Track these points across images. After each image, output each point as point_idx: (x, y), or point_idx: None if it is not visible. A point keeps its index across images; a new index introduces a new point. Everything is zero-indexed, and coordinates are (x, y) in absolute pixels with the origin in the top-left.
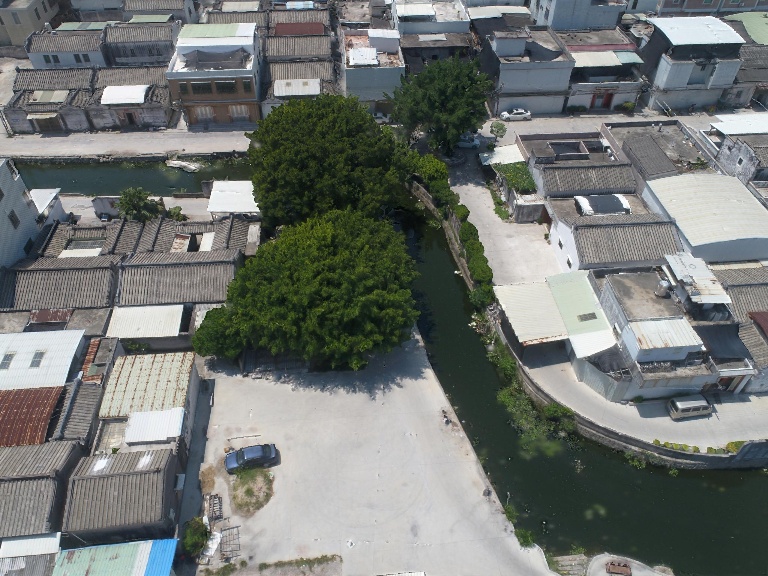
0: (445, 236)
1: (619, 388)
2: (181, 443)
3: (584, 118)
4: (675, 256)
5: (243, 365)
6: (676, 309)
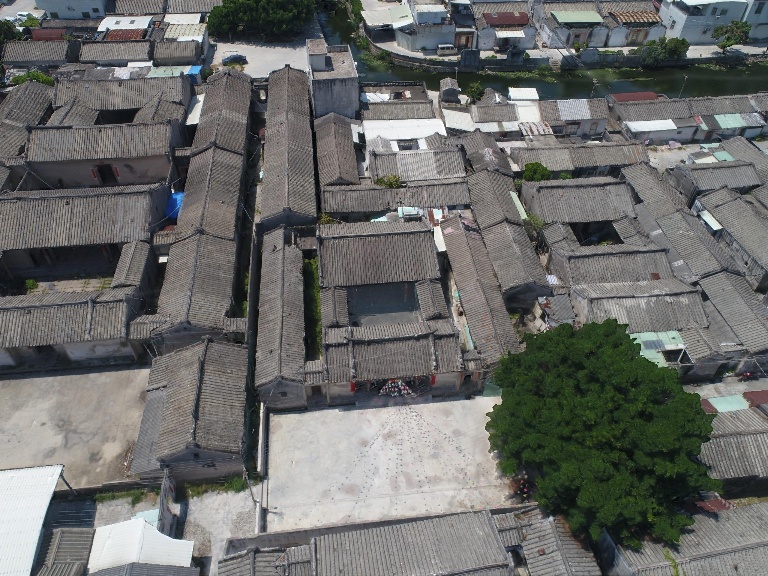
0: (346, 10)
1: (412, 40)
2: (202, 48)
3: None
4: None
5: (231, 38)
6: (439, 1)
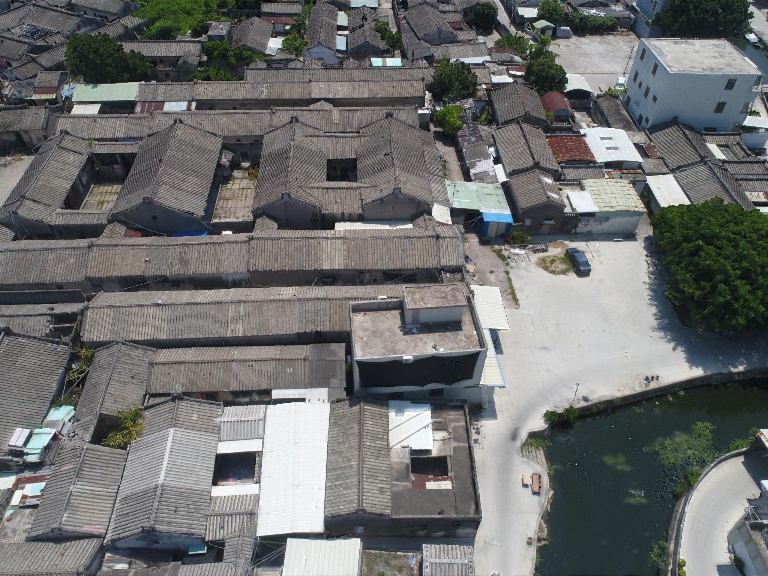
0: None
1: None
2: (575, 218)
3: None
4: None
5: (654, 250)
6: None
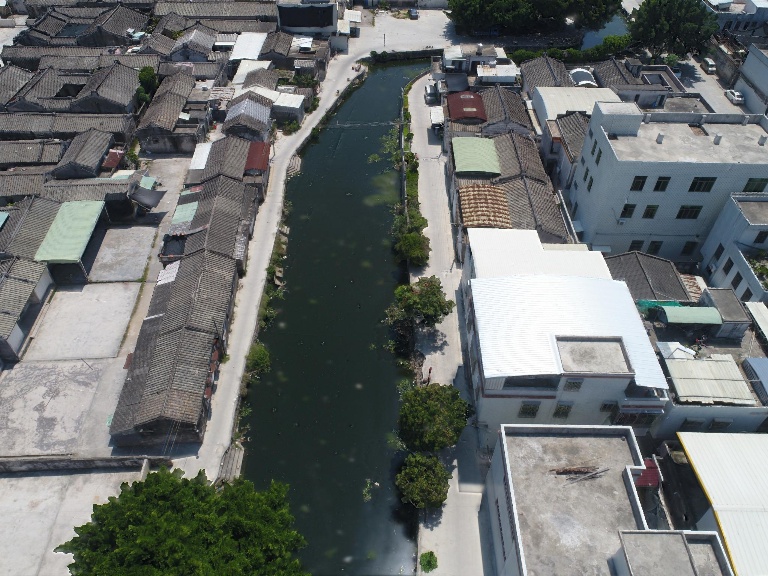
0: None
1: None
2: None
3: None
4: (515, 68)
5: None
6: None
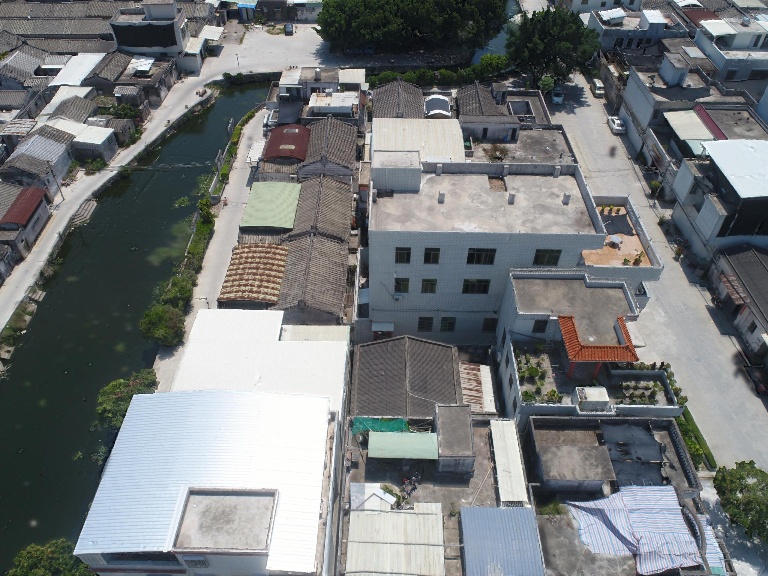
0: None
1: None
2: (294, 8)
3: (631, 166)
4: (354, 96)
5: None
6: None
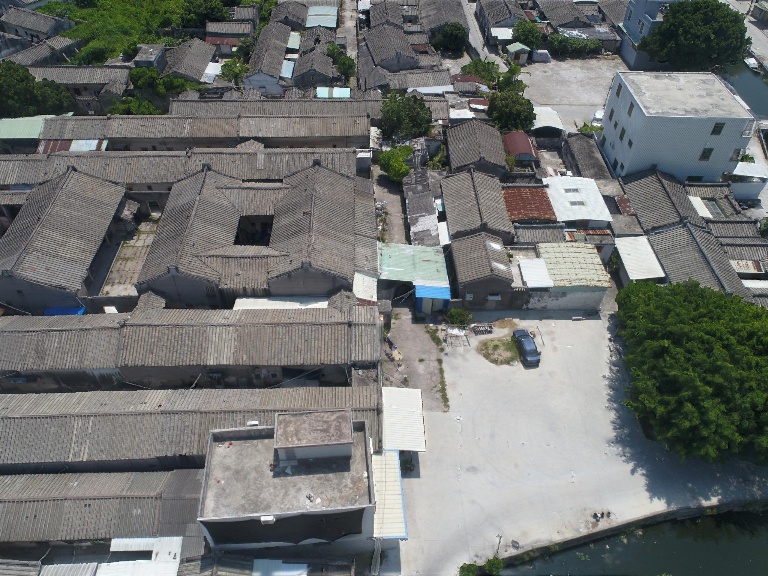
0: None
1: None
2: (526, 293)
3: None
4: None
5: None
6: None
